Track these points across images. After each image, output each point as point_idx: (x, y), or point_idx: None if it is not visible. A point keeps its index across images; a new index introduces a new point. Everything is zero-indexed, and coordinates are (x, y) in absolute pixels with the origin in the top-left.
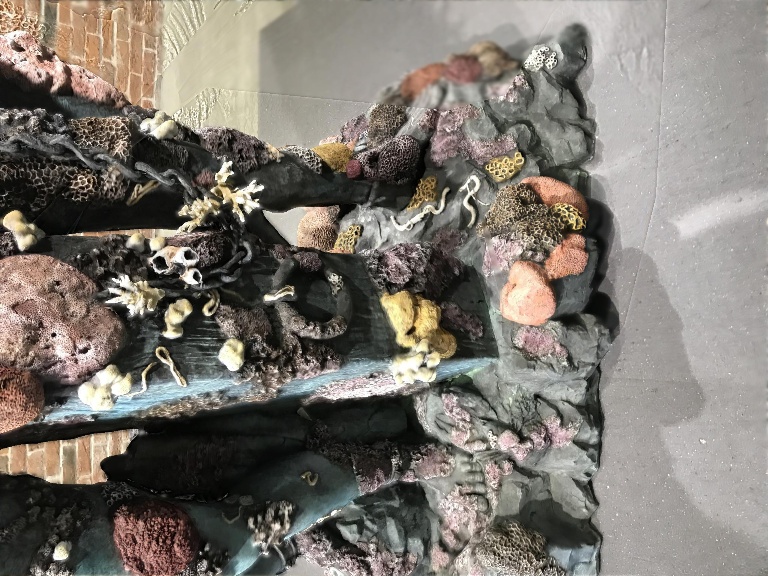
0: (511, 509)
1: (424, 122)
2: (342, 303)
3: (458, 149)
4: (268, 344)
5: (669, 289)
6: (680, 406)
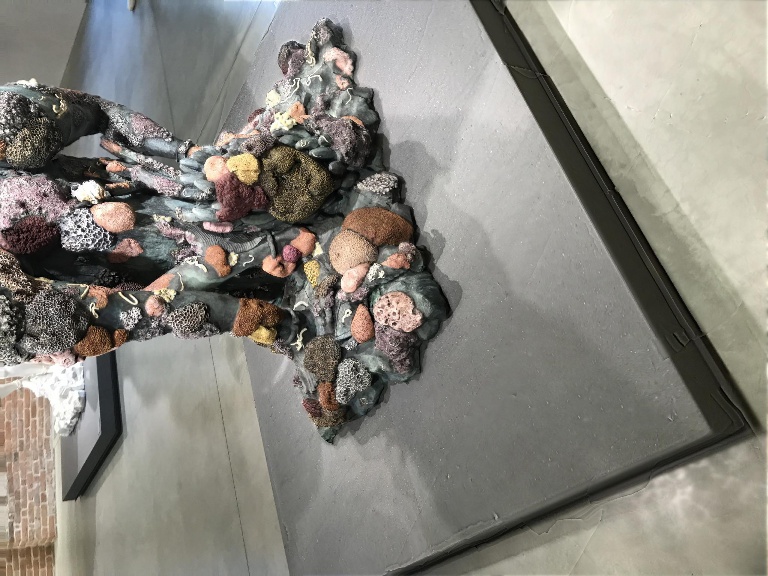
0: None
1: None
2: None
3: None
4: None
5: None
6: None
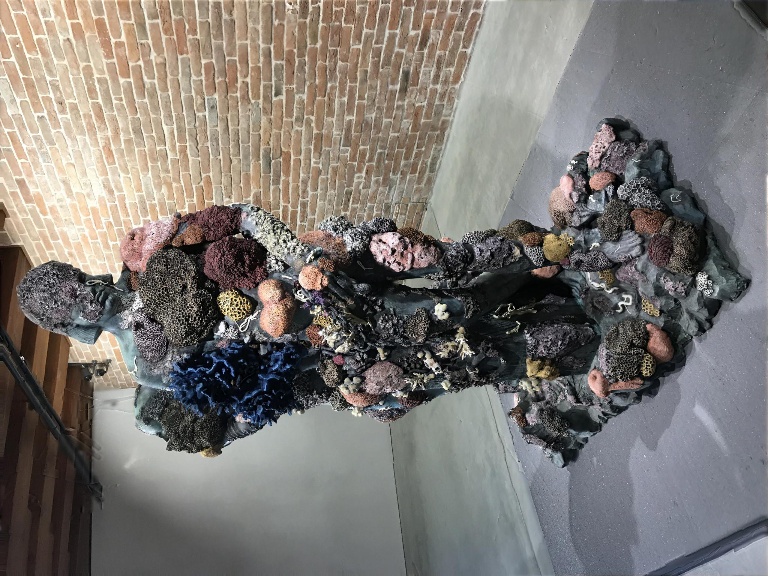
0: (563, 409)
1: (620, 260)
2: (502, 368)
3: (631, 282)
4: (462, 381)
5: (676, 414)
6: (648, 441)
